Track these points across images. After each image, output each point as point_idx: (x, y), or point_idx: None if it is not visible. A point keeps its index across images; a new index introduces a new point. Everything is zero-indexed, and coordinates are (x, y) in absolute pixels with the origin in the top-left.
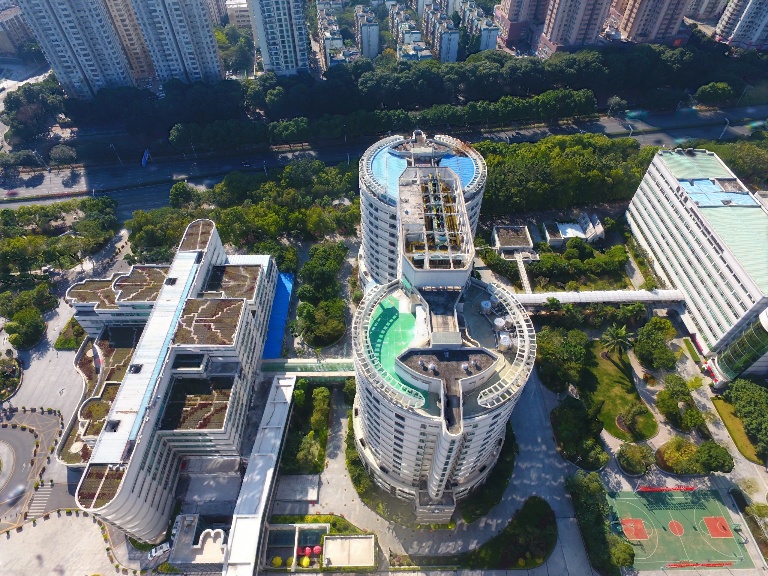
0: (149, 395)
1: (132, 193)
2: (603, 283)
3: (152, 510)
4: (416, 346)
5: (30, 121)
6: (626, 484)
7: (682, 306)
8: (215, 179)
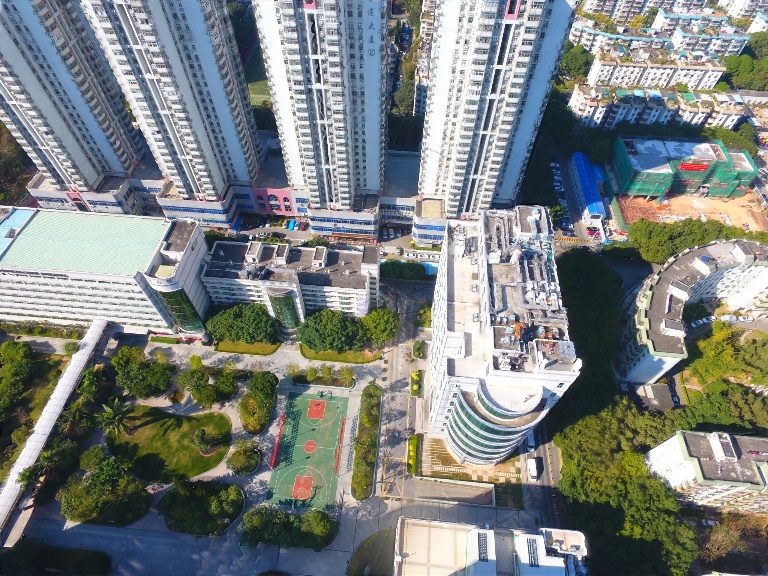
0: None
1: None
2: (39, 393)
3: None
4: None
5: None
6: (264, 475)
7: (114, 325)
8: None
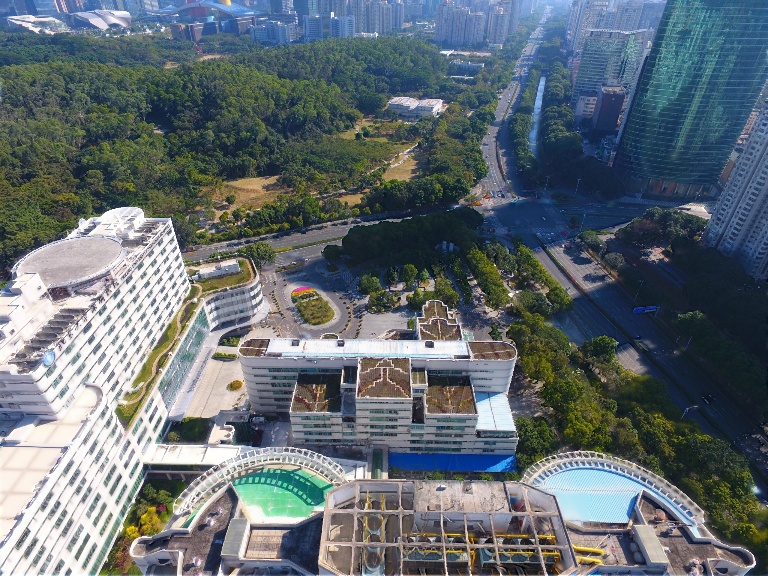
0: (316, 355)
1: (597, 317)
2: None
3: (257, 393)
4: (245, 509)
5: (638, 230)
6: None
7: None
8: (658, 374)
